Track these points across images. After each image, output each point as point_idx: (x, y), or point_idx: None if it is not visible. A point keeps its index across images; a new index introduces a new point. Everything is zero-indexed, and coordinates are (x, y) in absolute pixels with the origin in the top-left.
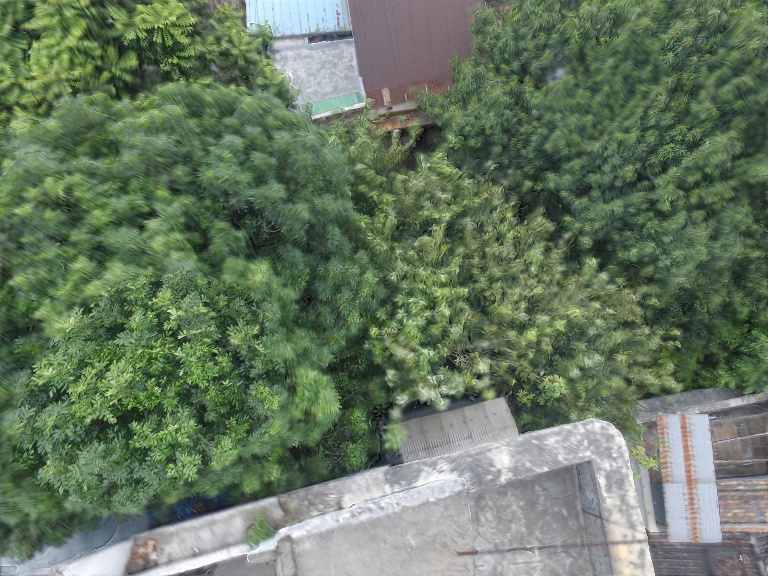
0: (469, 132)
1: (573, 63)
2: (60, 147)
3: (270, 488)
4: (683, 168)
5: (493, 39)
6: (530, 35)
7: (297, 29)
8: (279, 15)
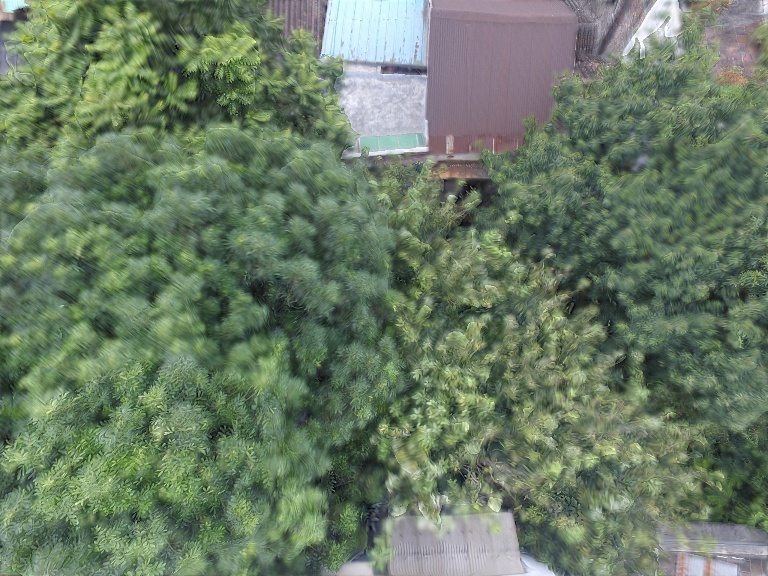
0: (530, 209)
1: (660, 157)
2: (90, 191)
3: None
4: (766, 305)
5: (576, 111)
6: (618, 115)
7: (372, 56)
8: (357, 38)
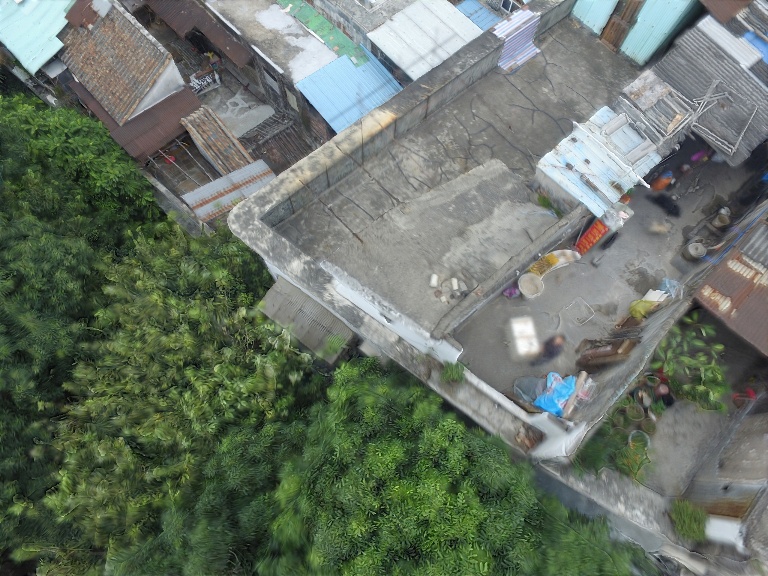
0: (2, 500)
1: None
2: None
3: (426, 391)
4: None
5: None
6: None
7: None
8: None
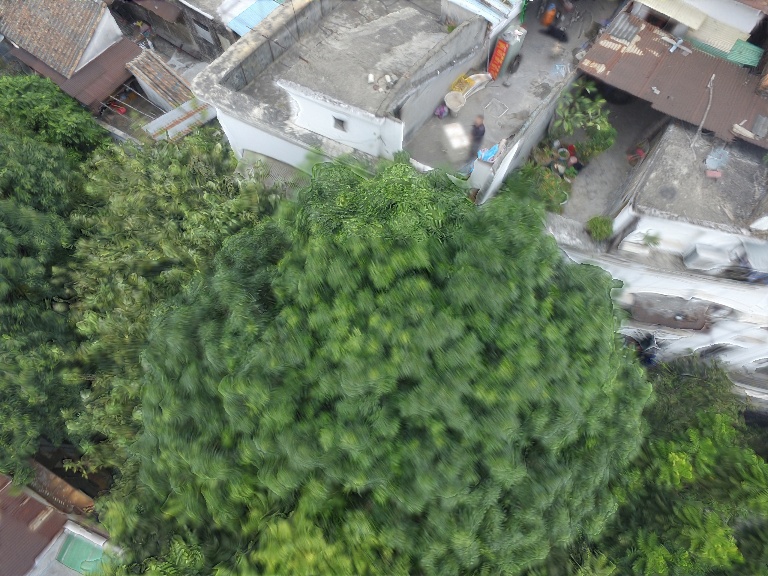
0: None
1: None
2: (334, 420)
3: None
4: None
5: None
6: None
7: None
8: None
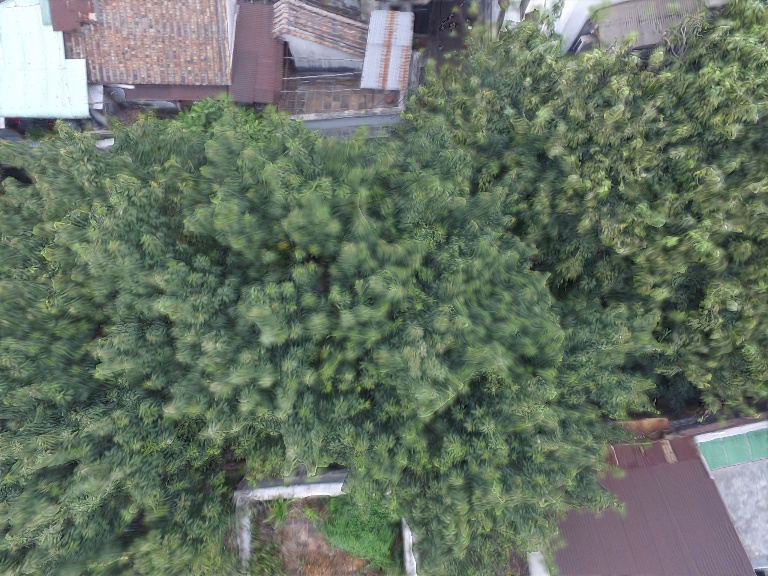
0: None
1: None
2: None
3: None
4: None
5: None
6: (559, 439)
7: None
8: None
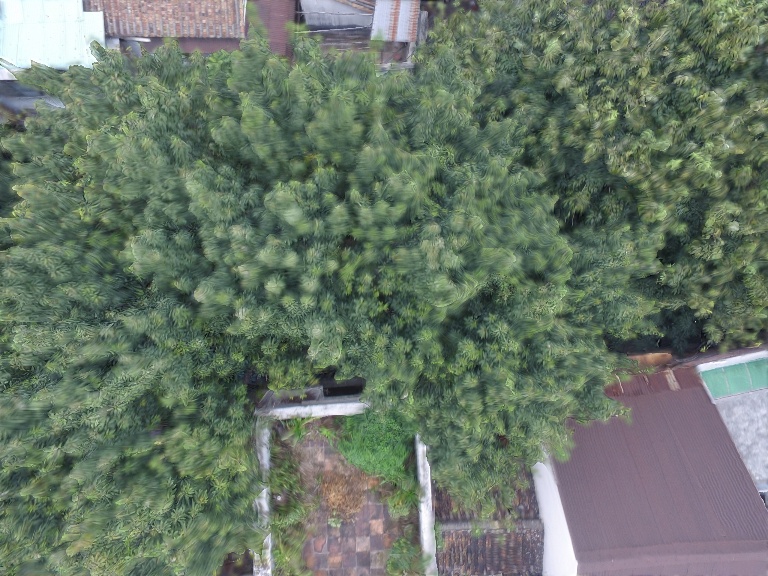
0: None
1: None
2: None
3: None
4: None
5: None
6: None
7: None
8: None
